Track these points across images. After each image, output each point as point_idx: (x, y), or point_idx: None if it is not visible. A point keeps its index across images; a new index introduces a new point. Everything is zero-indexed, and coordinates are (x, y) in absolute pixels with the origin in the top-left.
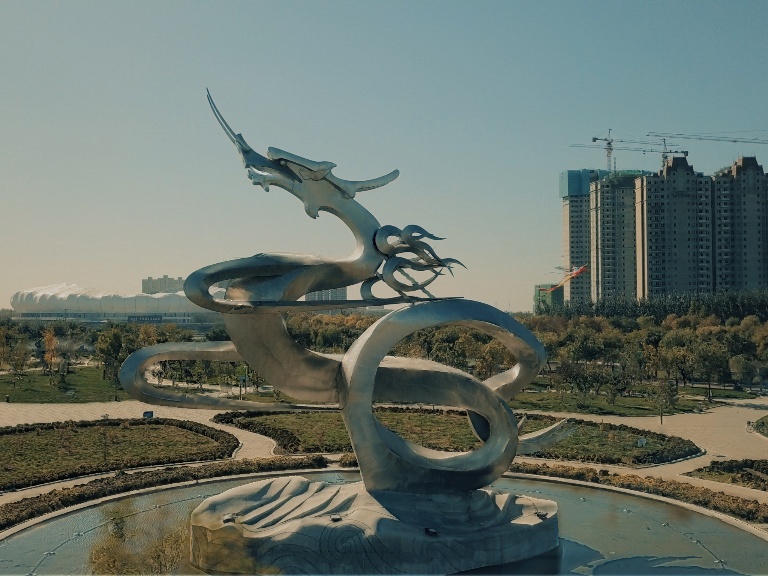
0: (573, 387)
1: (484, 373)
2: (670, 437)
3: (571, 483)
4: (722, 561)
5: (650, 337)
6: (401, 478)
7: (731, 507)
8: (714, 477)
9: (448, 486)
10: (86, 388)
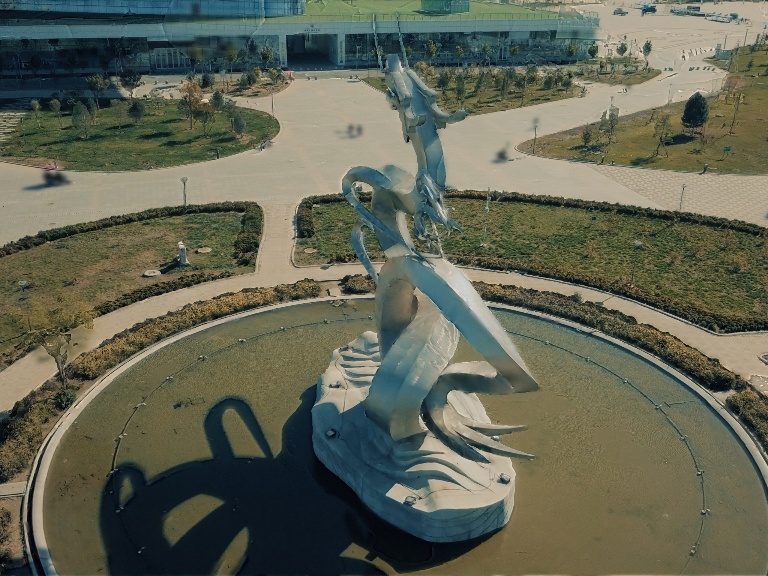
0: None
1: None
2: None
3: None
4: None
5: None
6: None
7: None
8: None
9: None
10: None
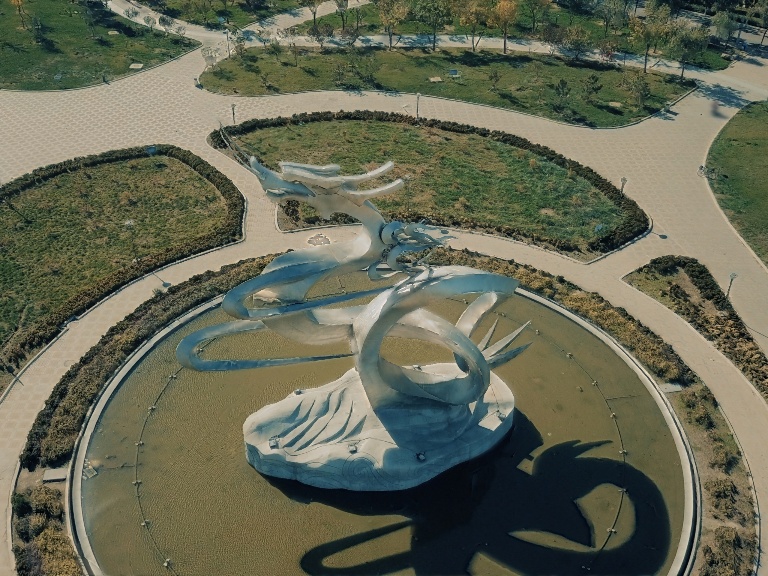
0: (554, 50)
1: None
2: (626, 199)
3: (531, 298)
4: (625, 452)
5: None
6: (399, 402)
7: (648, 363)
8: (649, 284)
9: (434, 405)
10: (64, 40)
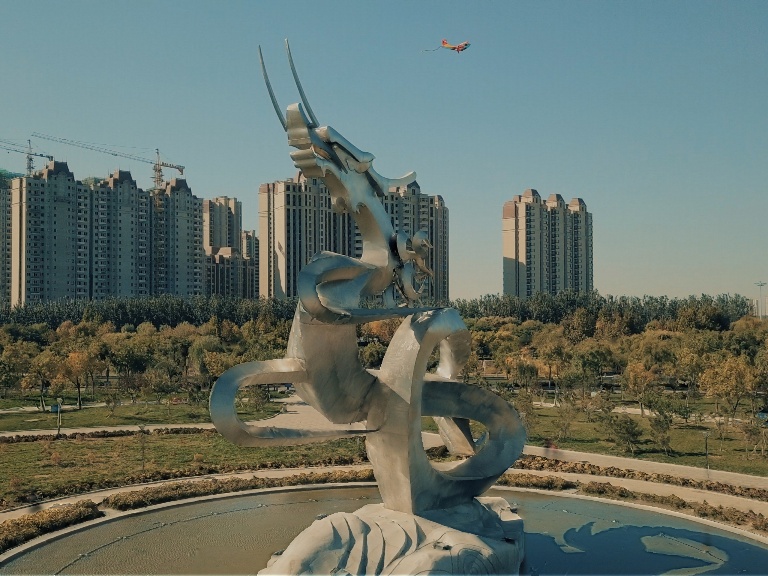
0: None
1: (5, 390)
2: None
3: (371, 485)
4: (617, 521)
5: (175, 344)
6: (436, 495)
7: (533, 482)
8: None
9: (465, 496)
10: None
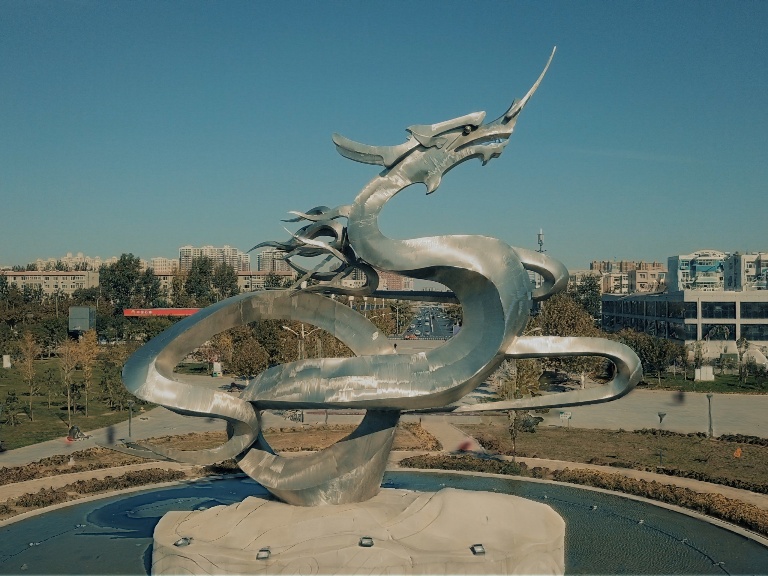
0: None
1: None
2: None
3: None
4: None
5: None
6: None
7: None
8: None
9: None
10: None
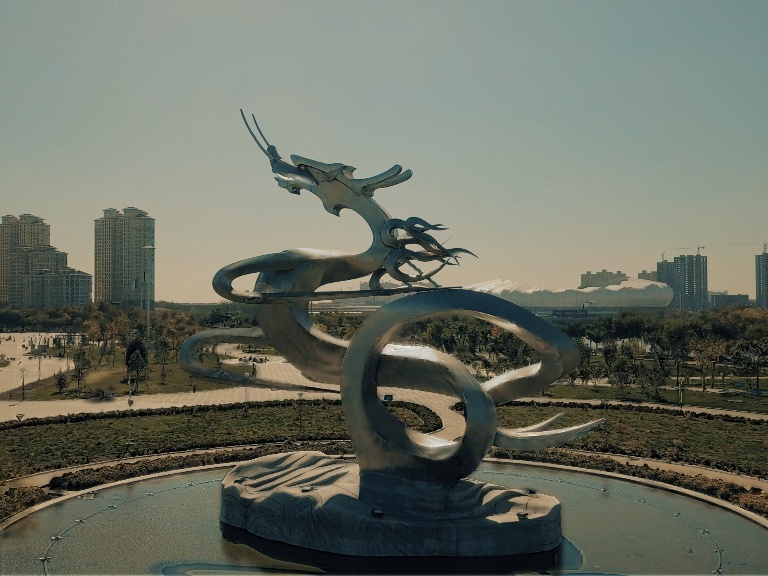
0: None
1: None
2: None
3: (696, 497)
4: None
5: None
6: (389, 461)
7: None
8: None
9: (430, 474)
10: None
